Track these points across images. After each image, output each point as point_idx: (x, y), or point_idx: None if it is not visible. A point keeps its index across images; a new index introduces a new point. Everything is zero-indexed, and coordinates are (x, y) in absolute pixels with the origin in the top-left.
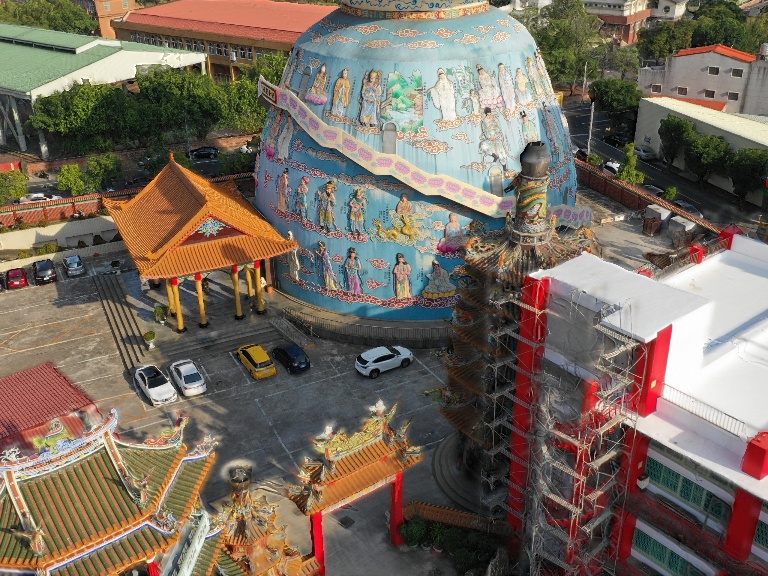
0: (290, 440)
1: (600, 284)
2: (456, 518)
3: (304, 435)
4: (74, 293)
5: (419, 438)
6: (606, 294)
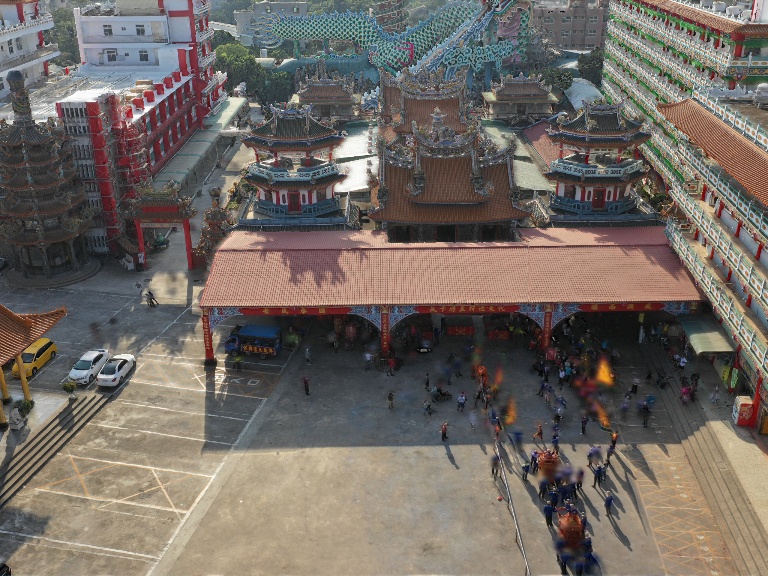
0: (107, 316)
1: (89, 96)
2: (128, 242)
3: (96, 316)
4: (1, 543)
5: (57, 294)
6: (96, 95)
